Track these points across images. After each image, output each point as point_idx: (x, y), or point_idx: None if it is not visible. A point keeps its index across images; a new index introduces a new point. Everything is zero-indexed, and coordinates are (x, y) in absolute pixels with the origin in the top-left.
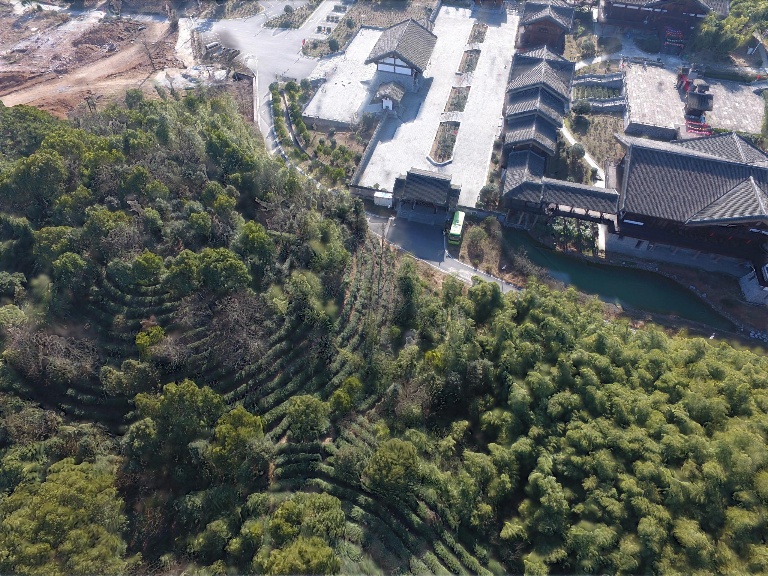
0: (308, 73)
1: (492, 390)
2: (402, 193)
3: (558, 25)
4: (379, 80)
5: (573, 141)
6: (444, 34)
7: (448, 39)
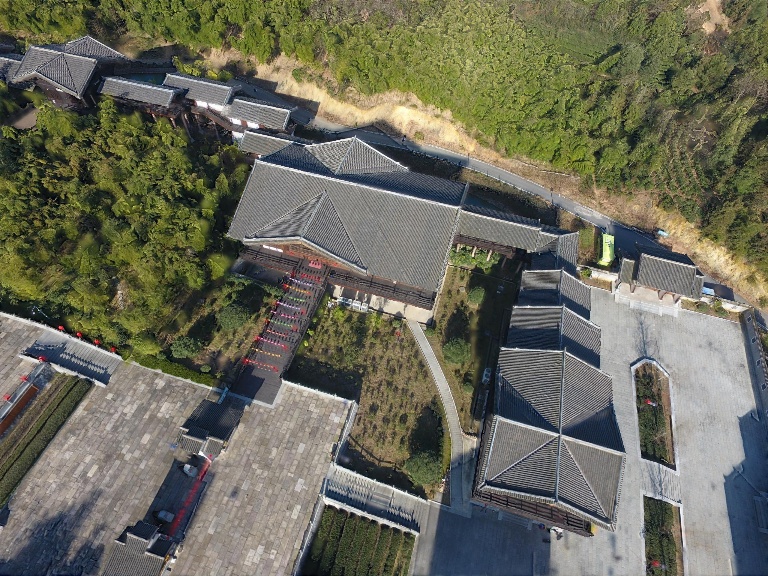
0: None
1: None
2: None
3: None
4: None
5: (446, 399)
6: None
7: None
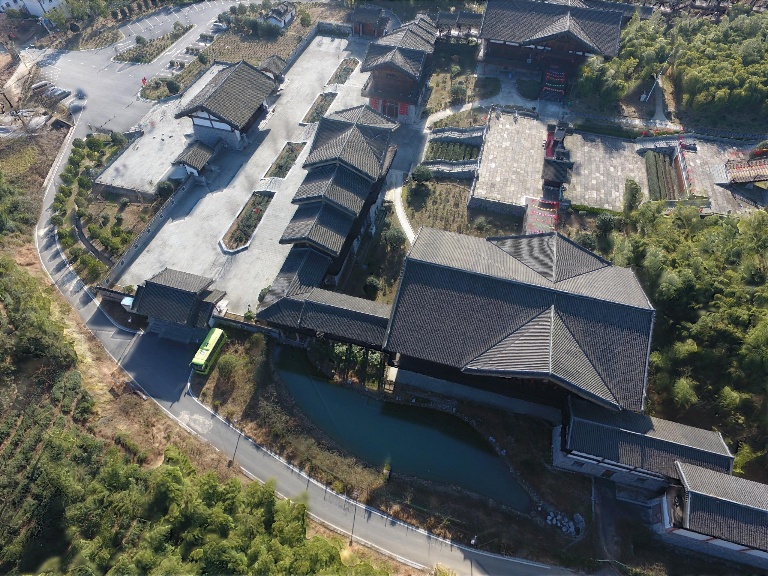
0: (135, 121)
1: None
2: (137, 308)
3: (402, 72)
4: (199, 135)
5: (404, 219)
6: (305, 72)
7: (307, 78)
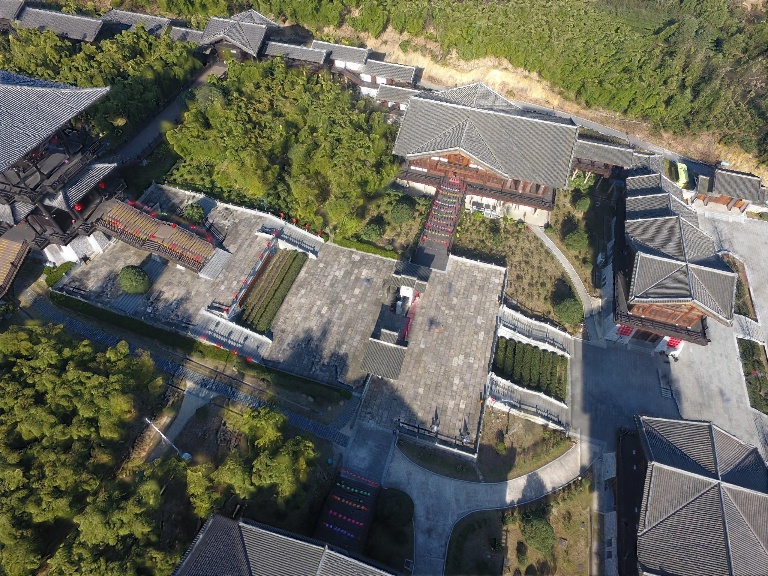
0: None
1: None
2: None
3: None
4: None
5: (572, 274)
6: None
7: None
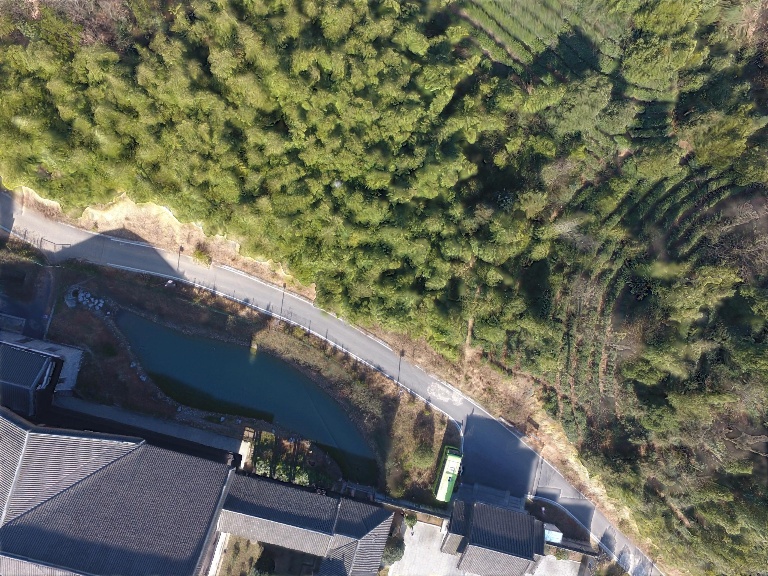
0: None
1: (461, 200)
2: None
3: None
4: None
5: None
6: None
7: None
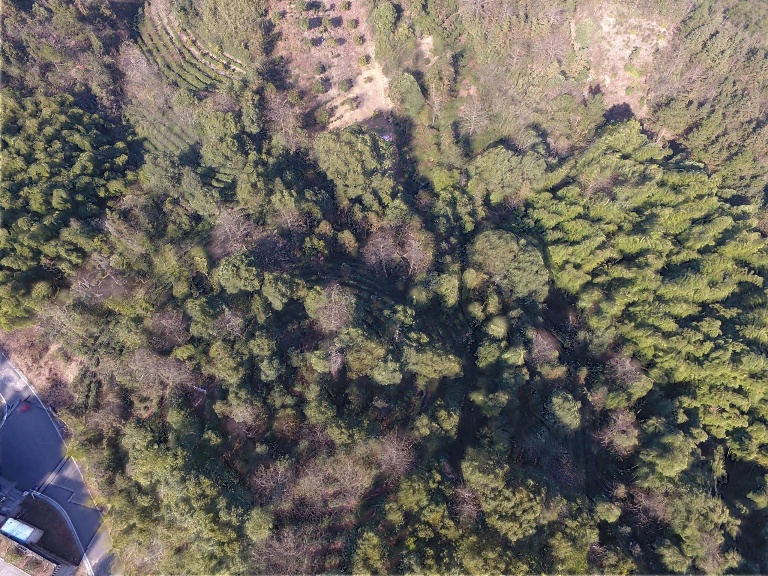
0: None
1: None
2: None
3: None
4: None
5: None
6: None
7: None
